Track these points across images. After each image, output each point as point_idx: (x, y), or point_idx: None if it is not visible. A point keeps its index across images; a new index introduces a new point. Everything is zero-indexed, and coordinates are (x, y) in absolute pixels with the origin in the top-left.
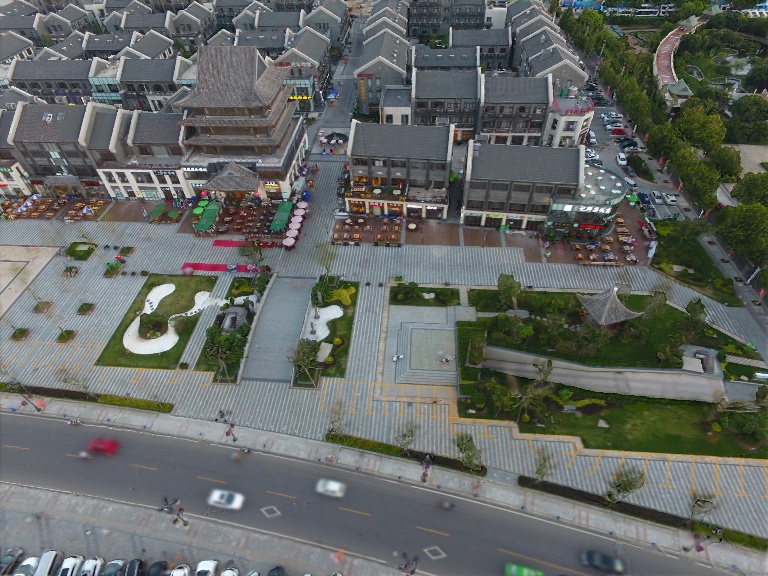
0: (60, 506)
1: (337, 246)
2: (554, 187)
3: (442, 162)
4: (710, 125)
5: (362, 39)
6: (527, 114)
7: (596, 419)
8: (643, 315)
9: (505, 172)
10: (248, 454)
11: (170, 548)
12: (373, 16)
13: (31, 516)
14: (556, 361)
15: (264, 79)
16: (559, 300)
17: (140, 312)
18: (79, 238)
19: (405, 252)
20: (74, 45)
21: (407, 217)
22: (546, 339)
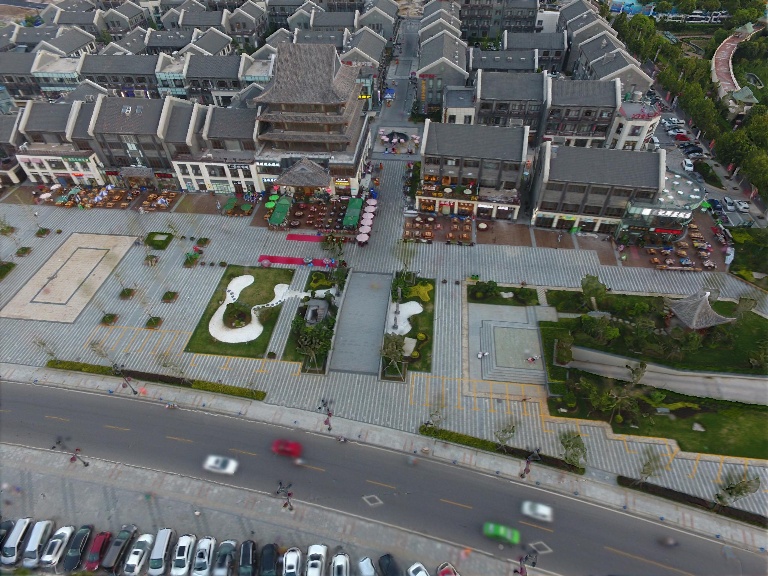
0: (167, 486)
1: (409, 243)
2: (633, 190)
3: (516, 163)
4: None
5: (411, 40)
6: (593, 118)
7: (691, 423)
8: (732, 321)
9: (583, 174)
10: (344, 443)
11: (278, 531)
12: (427, 17)
13: (140, 495)
14: None
15: (339, 77)
16: (643, 303)
17: (222, 302)
18: (155, 228)
19: (478, 251)
20: (137, 41)
21: (476, 217)
22: (634, 341)
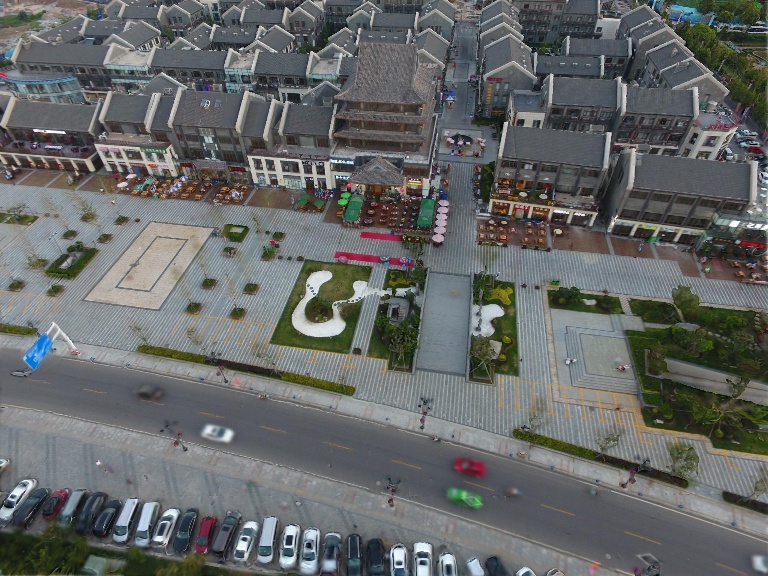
0: (265, 475)
1: (484, 246)
2: (721, 202)
3: (597, 169)
4: None
5: (466, 43)
6: (668, 126)
7: None
8: None
9: (669, 183)
10: (438, 443)
11: (381, 527)
12: (488, 21)
13: (240, 482)
14: (739, 378)
15: (418, 77)
16: (736, 317)
17: (303, 296)
18: (230, 221)
19: (555, 257)
20: (203, 36)
21: (550, 222)
22: (729, 355)
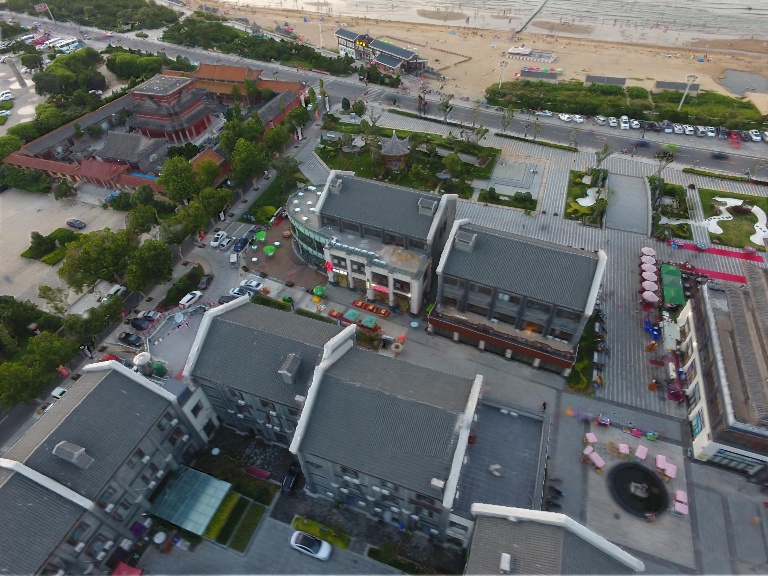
0: (716, 148)
1: None
2: None
3: None
4: (102, 235)
5: None
6: None
7: None
8: None
9: None
10: None
11: None
12: None
13: None
14: None
15: None
16: None
17: (767, 225)
18: None
19: None
20: None
21: None
22: None
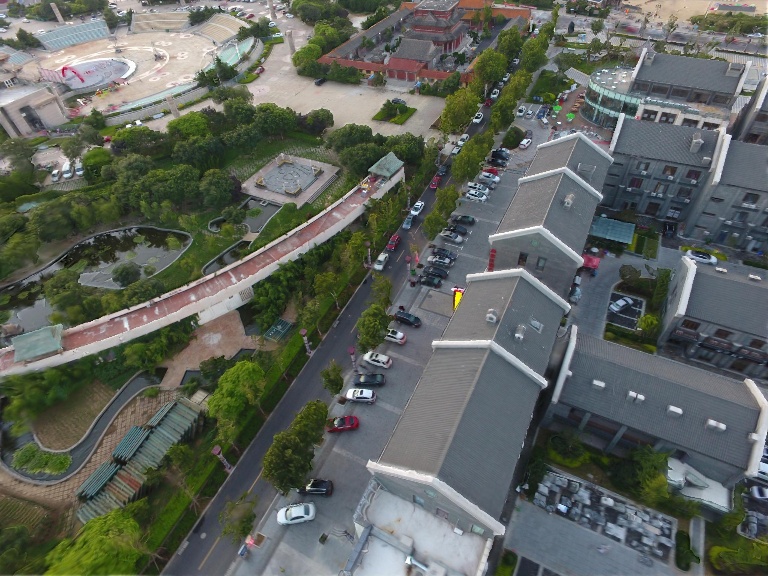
0: None
1: None
2: None
3: None
4: None
5: None
6: None
7: None
8: None
9: None
10: None
11: None
12: None
13: None
14: None
15: None
16: None
17: None
18: None
19: None
20: None
21: None
22: None
